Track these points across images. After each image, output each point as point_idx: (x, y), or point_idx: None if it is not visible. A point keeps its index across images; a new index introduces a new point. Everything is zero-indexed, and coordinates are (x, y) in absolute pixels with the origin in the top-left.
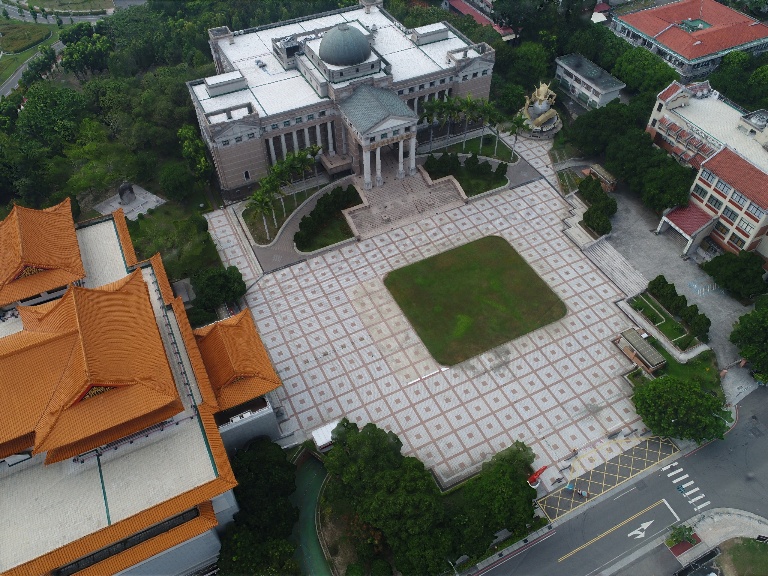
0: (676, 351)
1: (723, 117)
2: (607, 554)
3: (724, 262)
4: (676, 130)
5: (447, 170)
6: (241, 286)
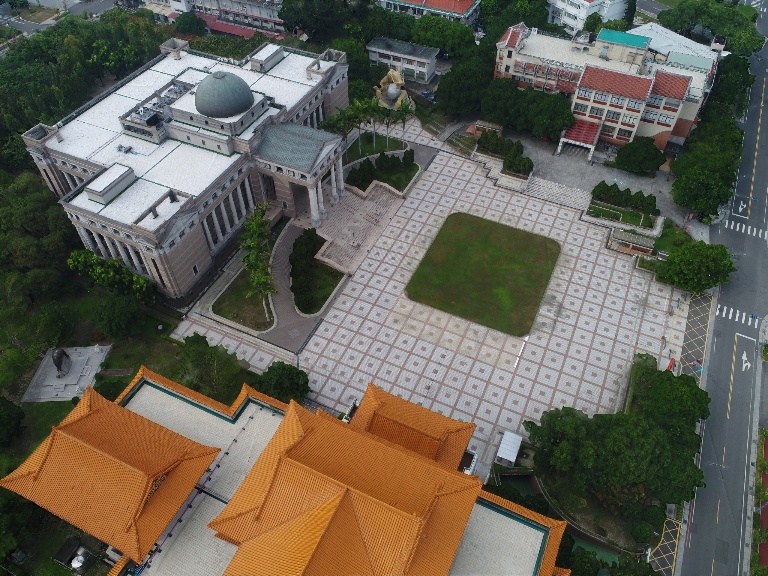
0: (648, 231)
1: (554, 46)
2: (746, 392)
3: (630, 152)
4: (533, 68)
5: (369, 177)
6: (305, 375)
